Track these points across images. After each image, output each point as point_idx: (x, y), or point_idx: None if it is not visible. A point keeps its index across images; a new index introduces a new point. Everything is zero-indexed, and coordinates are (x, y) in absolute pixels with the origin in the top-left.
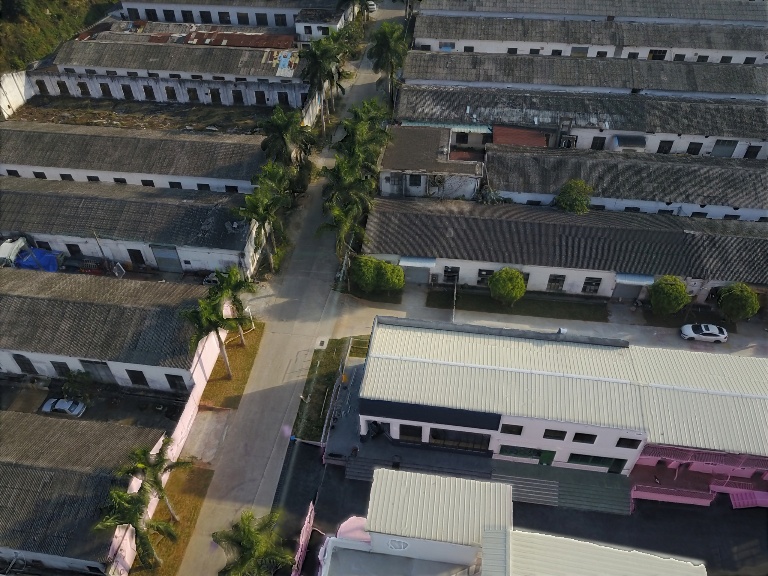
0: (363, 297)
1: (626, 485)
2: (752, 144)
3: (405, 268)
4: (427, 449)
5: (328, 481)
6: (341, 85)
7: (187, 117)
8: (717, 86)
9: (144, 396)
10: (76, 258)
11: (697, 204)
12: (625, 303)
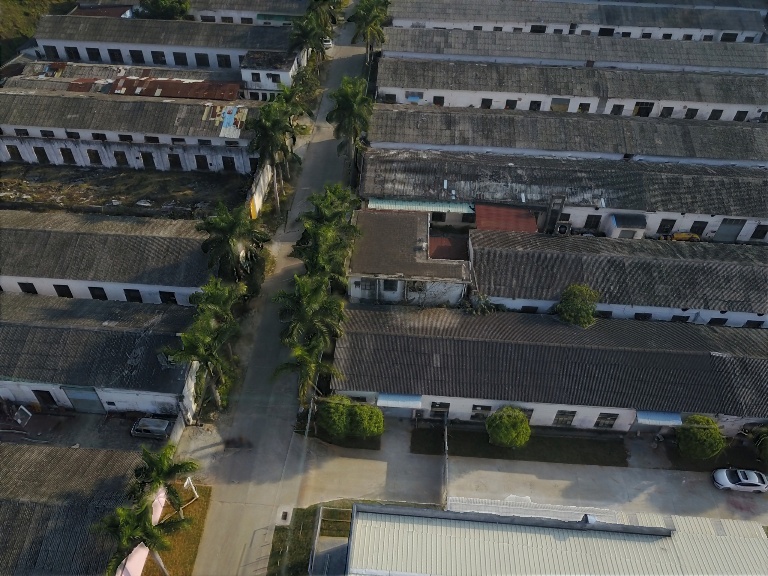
0: (333, 442)
1: None
2: (761, 223)
3: (384, 409)
4: None
5: None
6: (296, 143)
7: (114, 187)
8: (716, 151)
9: None
10: None
11: (717, 310)
12: (644, 438)
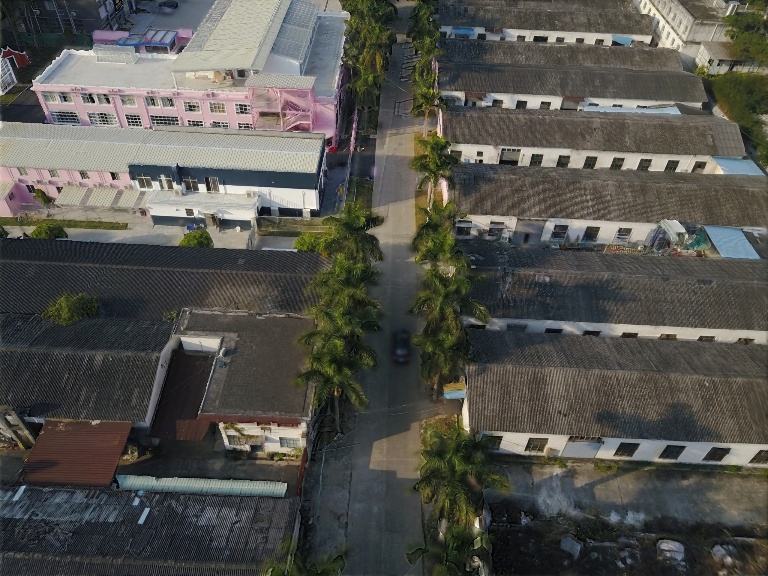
0: None
1: None
2: None
3: None
4: None
5: None
6: None
7: None
8: None
9: None
10: None
11: None
12: None
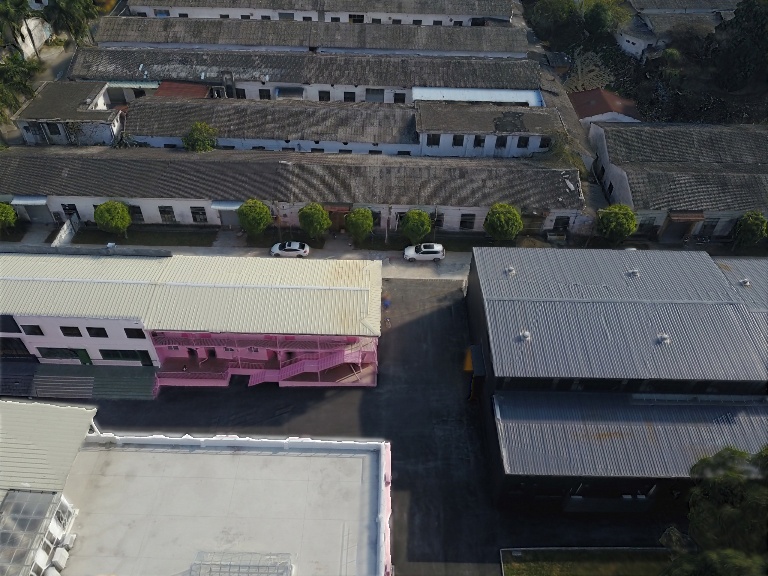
0: None
1: (154, 374)
2: (396, 92)
3: (16, 206)
4: None
5: None
6: (50, 51)
7: None
8: (383, 43)
9: None
10: None
11: (311, 141)
12: (234, 230)
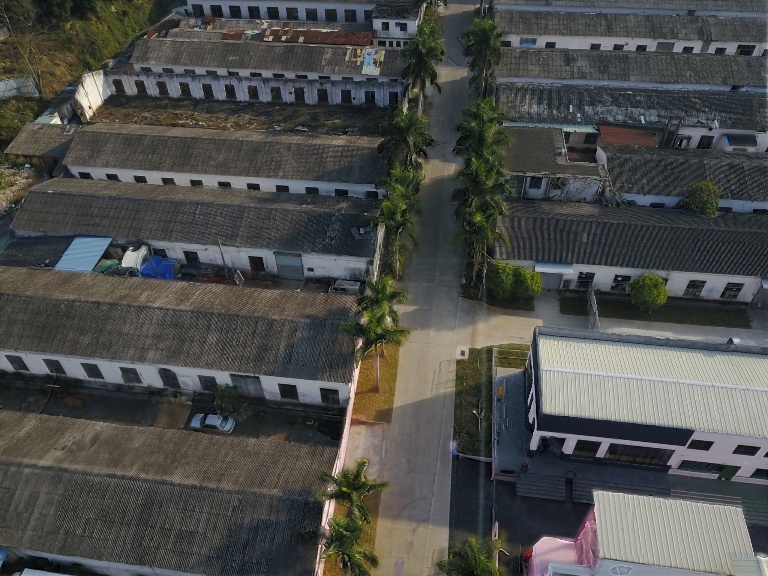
0: (494, 304)
1: None
2: None
3: (541, 274)
4: (599, 464)
5: (500, 498)
6: None
7: (272, 117)
8: None
9: (293, 410)
10: (193, 265)
11: None
12: (765, 309)
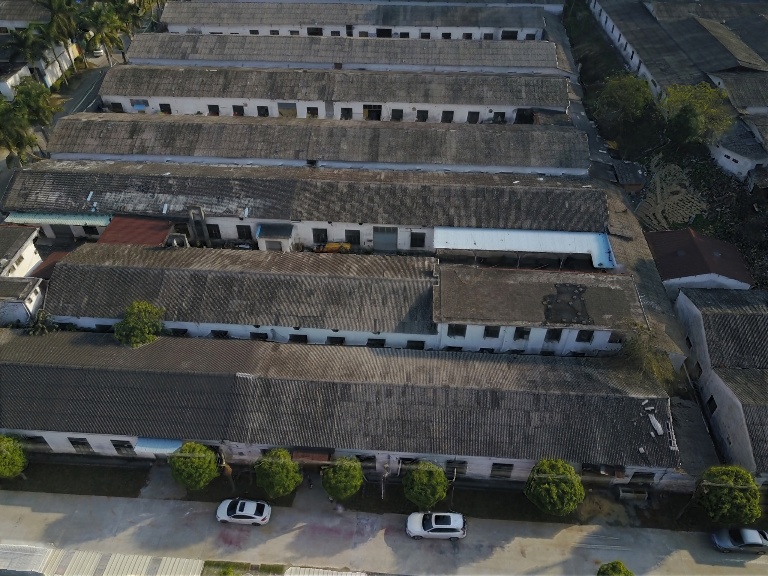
0: None
1: None
2: (413, 231)
3: None
4: None
5: None
6: (3, 155)
7: None
8: (400, 155)
9: None
10: None
11: (288, 327)
12: None
